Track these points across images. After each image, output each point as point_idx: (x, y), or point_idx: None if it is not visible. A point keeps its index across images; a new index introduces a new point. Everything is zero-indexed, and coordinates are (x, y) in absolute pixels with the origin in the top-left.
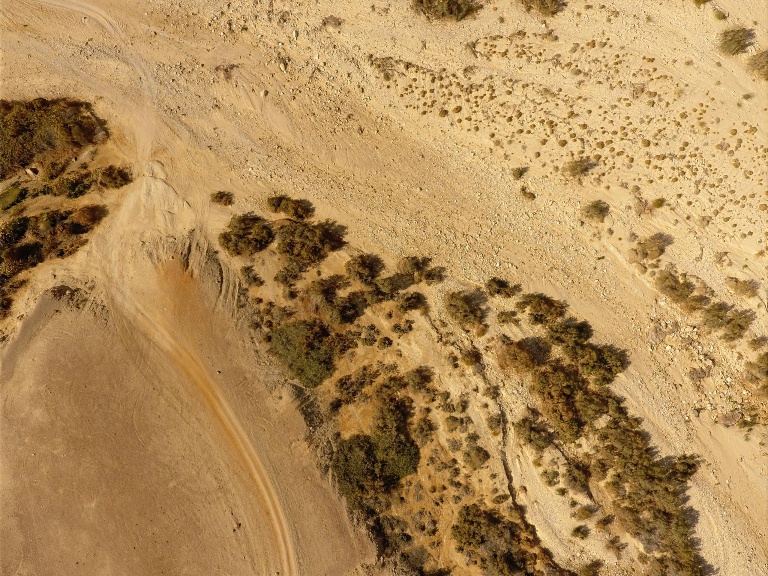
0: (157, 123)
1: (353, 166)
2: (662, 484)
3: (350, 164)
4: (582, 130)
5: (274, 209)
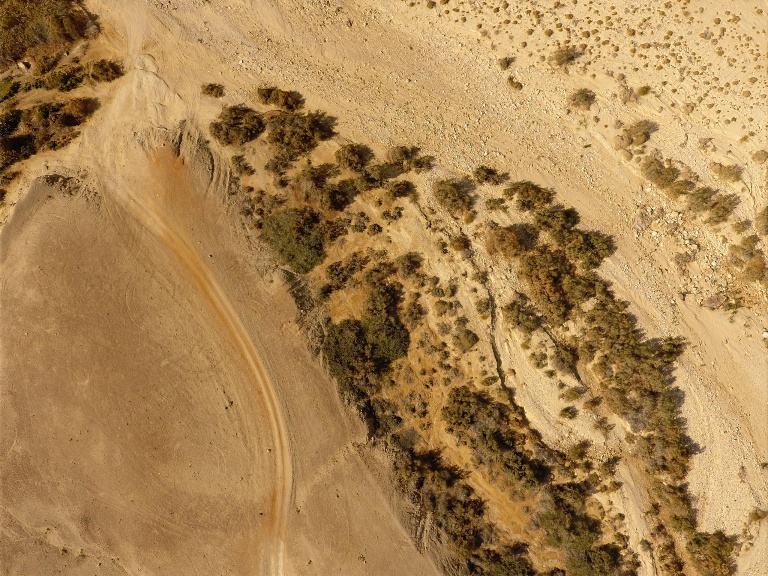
0: (148, 17)
1: (342, 58)
2: (648, 361)
3: (339, 56)
4: (568, 20)
5: (264, 101)
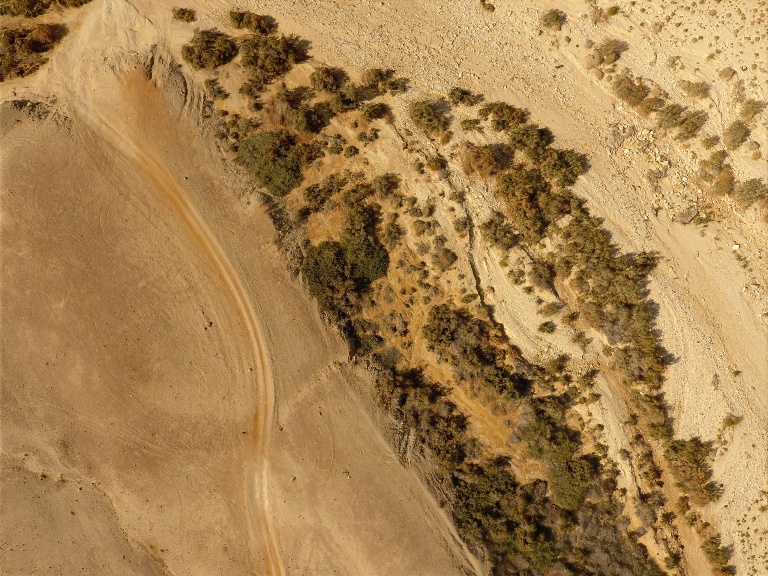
0: None
1: None
2: (623, 272)
3: None
4: None
5: (237, 25)
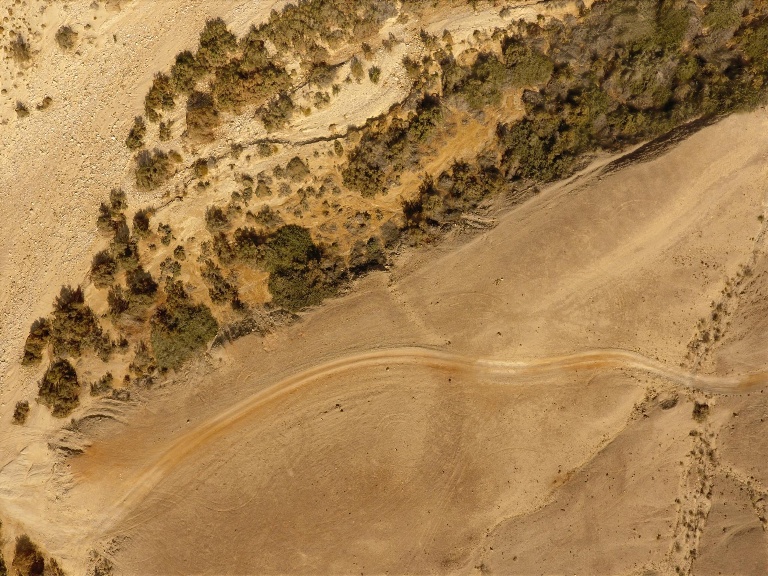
0: None
1: (1, 277)
2: None
3: None
4: None
5: (37, 360)
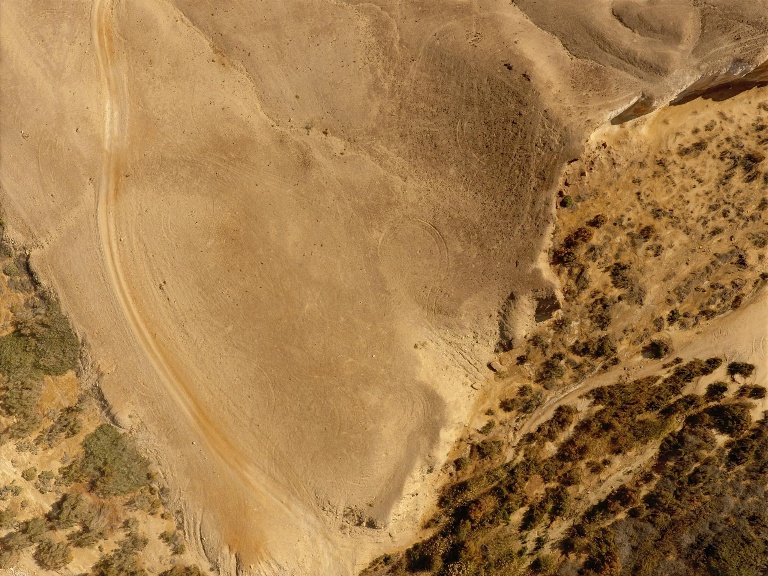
0: None
1: None
2: None
3: None
4: None
5: None
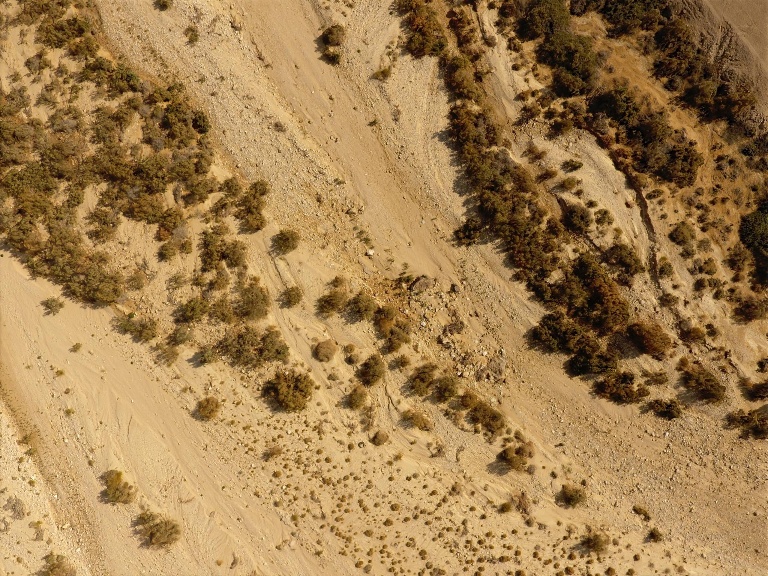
0: None
1: None
2: None
3: None
4: None
5: None
